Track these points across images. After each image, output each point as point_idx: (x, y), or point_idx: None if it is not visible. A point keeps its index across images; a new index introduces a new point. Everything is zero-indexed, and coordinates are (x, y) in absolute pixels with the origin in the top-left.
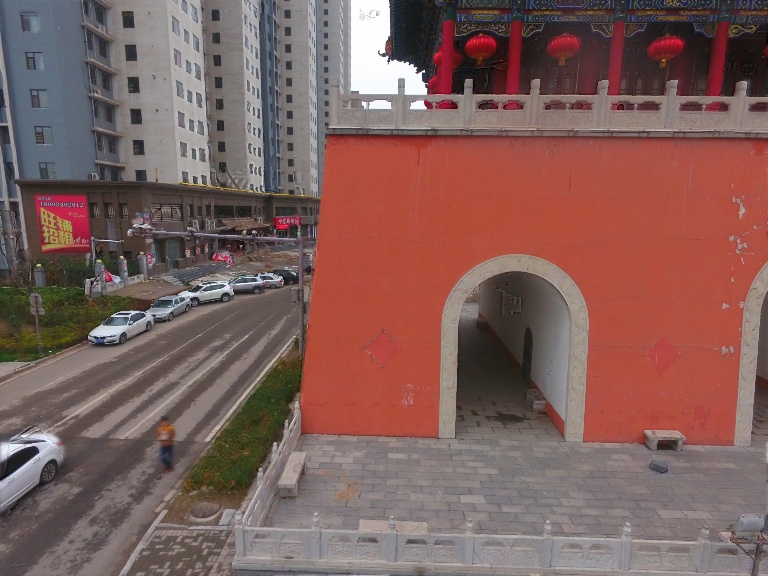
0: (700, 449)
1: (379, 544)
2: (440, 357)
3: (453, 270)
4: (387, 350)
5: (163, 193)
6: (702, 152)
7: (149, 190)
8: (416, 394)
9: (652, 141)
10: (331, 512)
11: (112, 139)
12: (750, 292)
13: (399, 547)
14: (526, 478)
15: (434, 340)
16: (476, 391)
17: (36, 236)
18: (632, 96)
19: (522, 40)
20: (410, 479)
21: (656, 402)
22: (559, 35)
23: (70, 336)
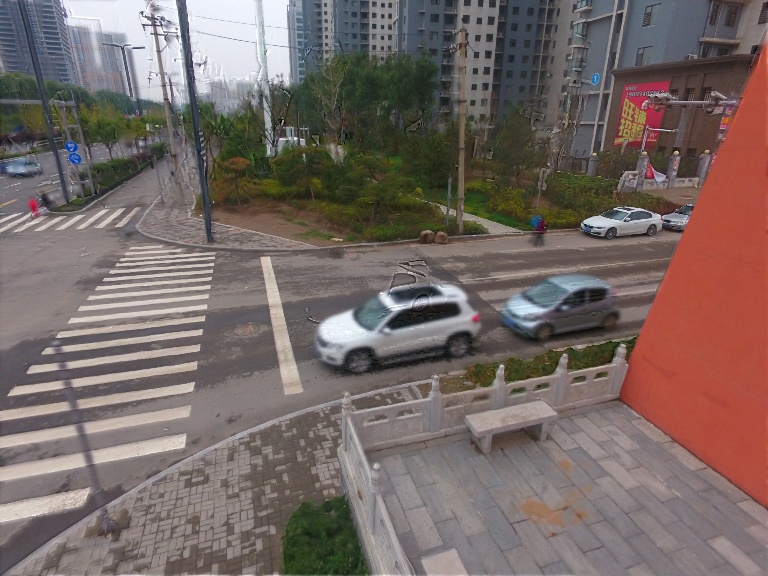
0: None
1: None
2: None
3: None
4: None
5: None
6: None
7: None
8: None
9: None
10: (484, 508)
11: (735, 7)
12: None
13: None
14: None
15: None
16: None
17: (613, 129)
18: None
19: None
20: None
21: None
22: None
23: (569, 219)
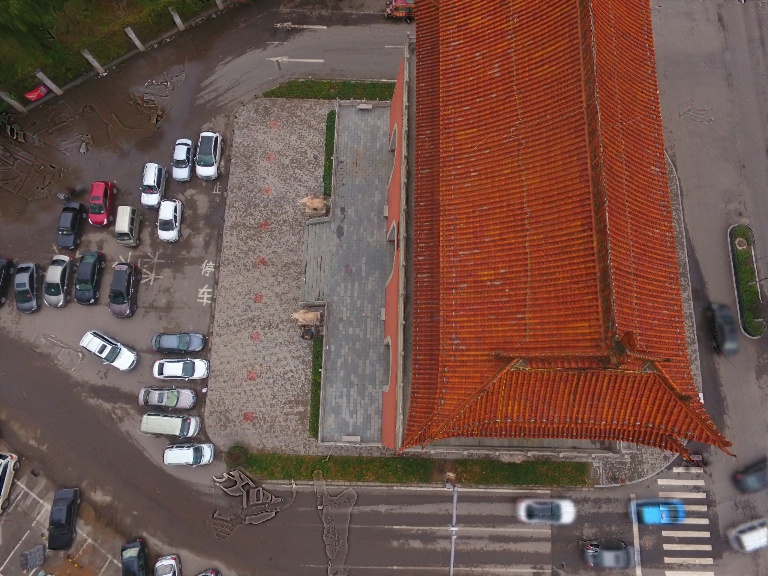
0: None
1: None
2: None
3: None
4: None
5: None
6: None
7: None
8: None
9: None
10: None
11: None
12: None
13: None
14: None
15: None
16: None
17: None
18: None
19: None
20: None
21: None
22: None
23: None
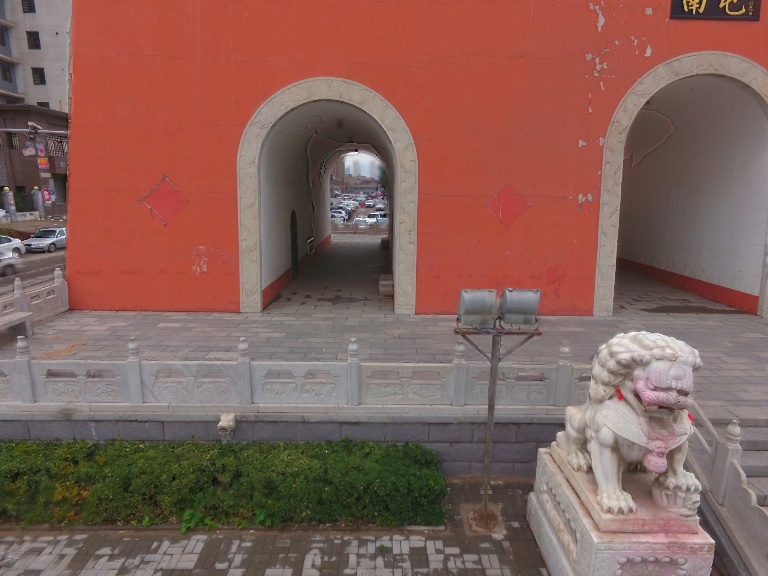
0: (551, 318)
1: (8, 378)
2: (237, 211)
3: (248, 98)
4: (171, 203)
5: (63, 124)
6: None
7: (42, 117)
8: (210, 258)
9: None
10: None
11: (6, 65)
12: (611, 126)
13: (37, 382)
14: (313, 339)
15: (229, 189)
16: (327, 282)
17: None
18: None
19: None
20: (161, 341)
21: (501, 264)
22: None
23: None
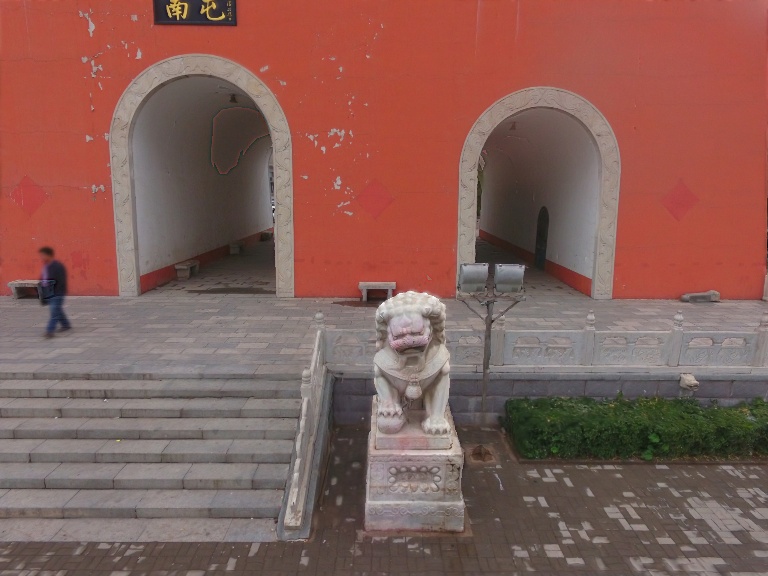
0: (71, 298)
1: None
2: None
3: None
4: None
5: None
6: None
7: None
8: None
9: None
10: None
11: None
12: (113, 122)
13: None
14: None
15: None
16: None
17: None
18: None
19: None
20: None
21: (29, 249)
22: None
23: None
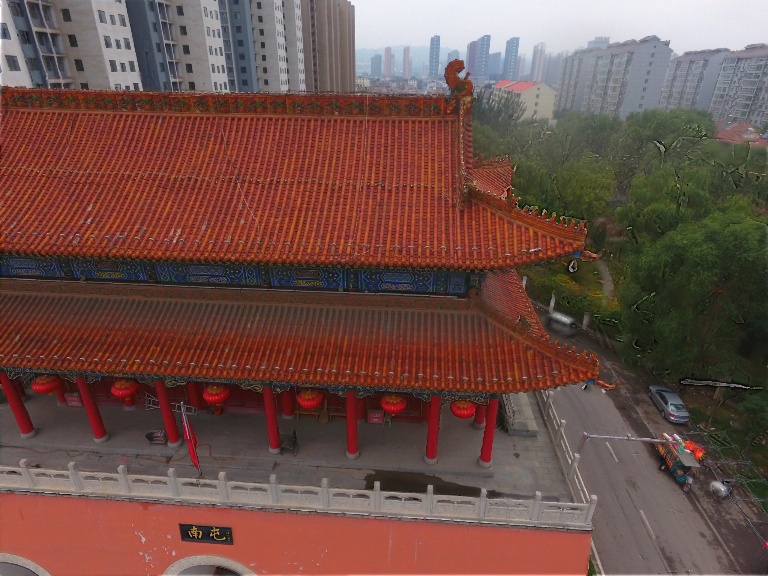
0: None
1: None
2: None
3: None
4: None
5: None
6: (106, 506)
7: None
8: None
9: (69, 498)
10: None
11: None
12: None
13: None
14: None
15: None
16: None
17: None
18: (46, 471)
19: (10, 381)
20: None
21: None
22: (40, 376)
23: None
